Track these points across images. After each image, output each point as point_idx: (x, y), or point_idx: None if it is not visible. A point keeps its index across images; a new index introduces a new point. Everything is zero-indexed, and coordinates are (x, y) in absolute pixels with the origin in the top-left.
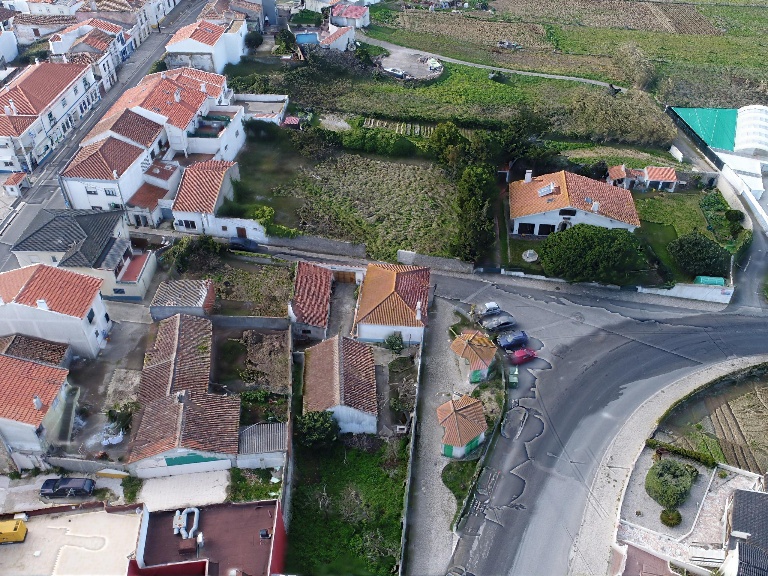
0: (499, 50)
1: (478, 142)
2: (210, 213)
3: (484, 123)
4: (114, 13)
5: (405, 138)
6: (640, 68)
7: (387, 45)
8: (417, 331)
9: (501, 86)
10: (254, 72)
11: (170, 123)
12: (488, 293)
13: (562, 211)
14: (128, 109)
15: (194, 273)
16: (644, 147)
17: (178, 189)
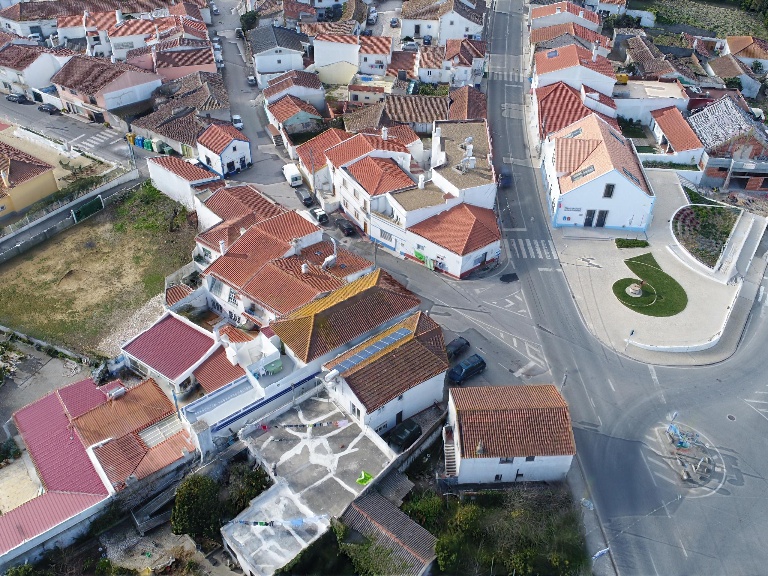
0: None
1: None
2: (624, 5)
3: None
4: None
5: None
6: None
7: None
8: (767, 64)
9: None
10: None
11: None
12: None
13: None
14: None
15: None
16: None
17: None
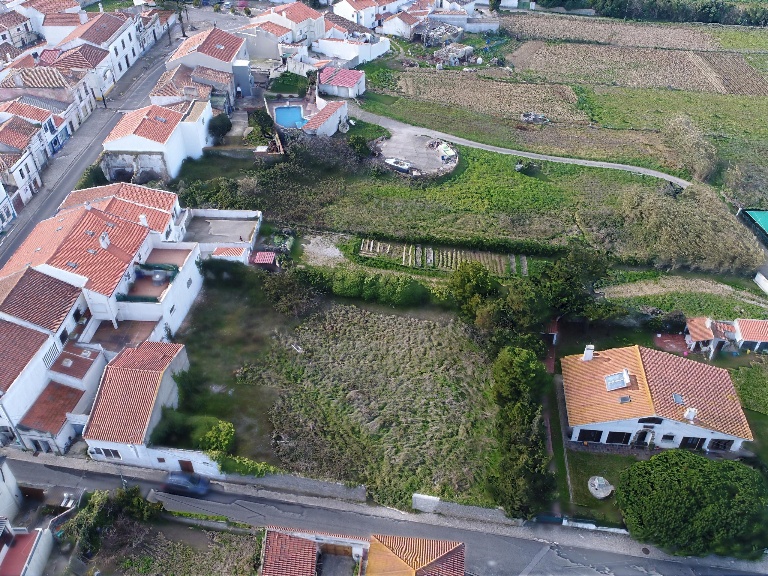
0: (524, 125)
1: (518, 303)
2: (138, 444)
3: (516, 246)
4: (44, 89)
5: (416, 282)
6: (700, 153)
7: (387, 122)
8: None
9: (531, 181)
10: (219, 173)
11: (90, 287)
12: (546, 566)
13: (643, 418)
14: (31, 268)
15: (109, 556)
16: (722, 276)
17: (94, 402)
